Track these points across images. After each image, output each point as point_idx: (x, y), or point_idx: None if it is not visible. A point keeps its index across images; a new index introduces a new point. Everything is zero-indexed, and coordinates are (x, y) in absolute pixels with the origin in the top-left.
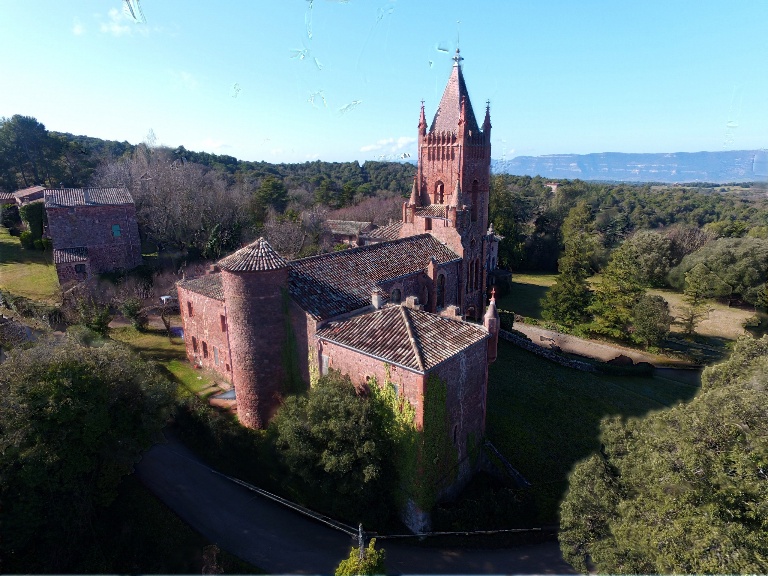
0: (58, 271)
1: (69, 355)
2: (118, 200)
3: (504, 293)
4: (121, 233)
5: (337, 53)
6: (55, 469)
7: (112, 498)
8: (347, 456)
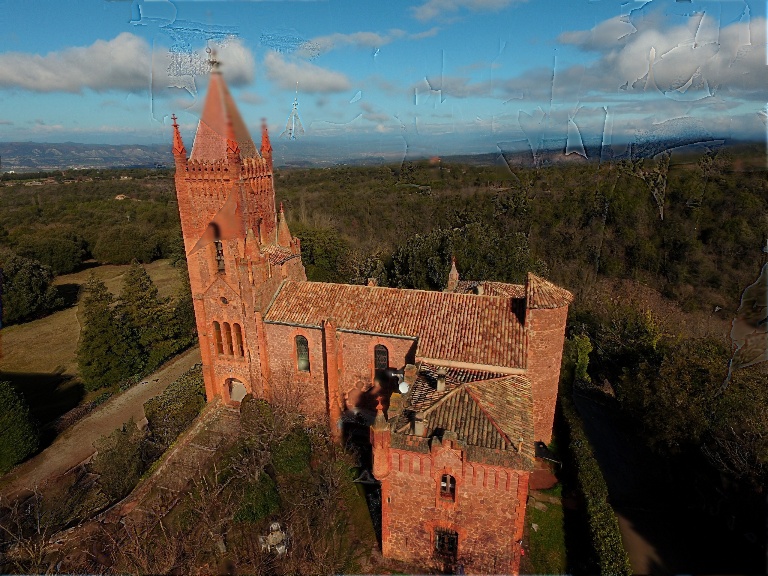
0: None
1: None
2: None
3: None
4: None
5: None
6: None
7: None
8: None
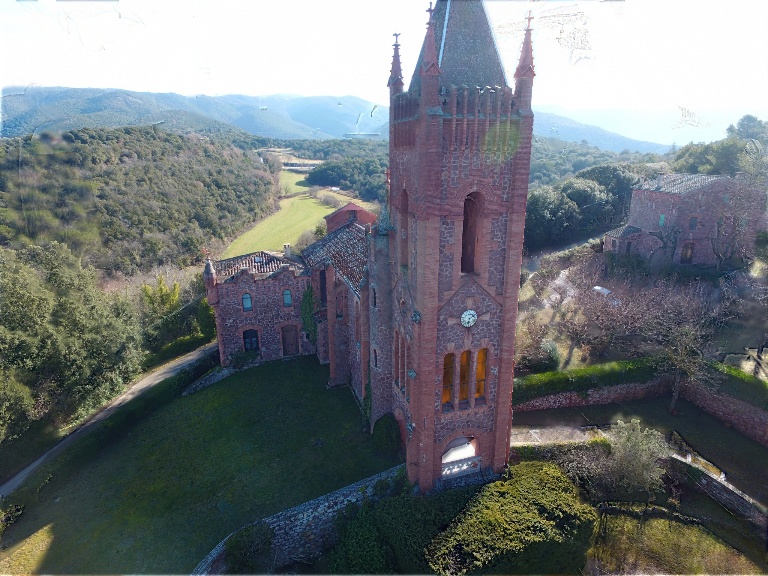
0: None
1: (321, 225)
2: None
3: None
4: (664, 223)
5: None
6: None
7: None
8: None
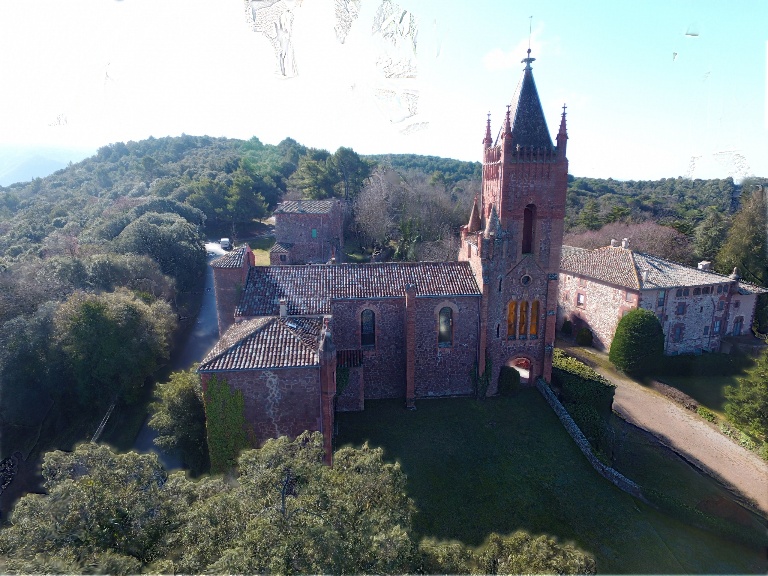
0: (271, 258)
1: (93, 298)
2: (319, 210)
3: (735, 370)
4: (317, 235)
5: (434, 74)
6: (91, 365)
7: (130, 400)
8: None
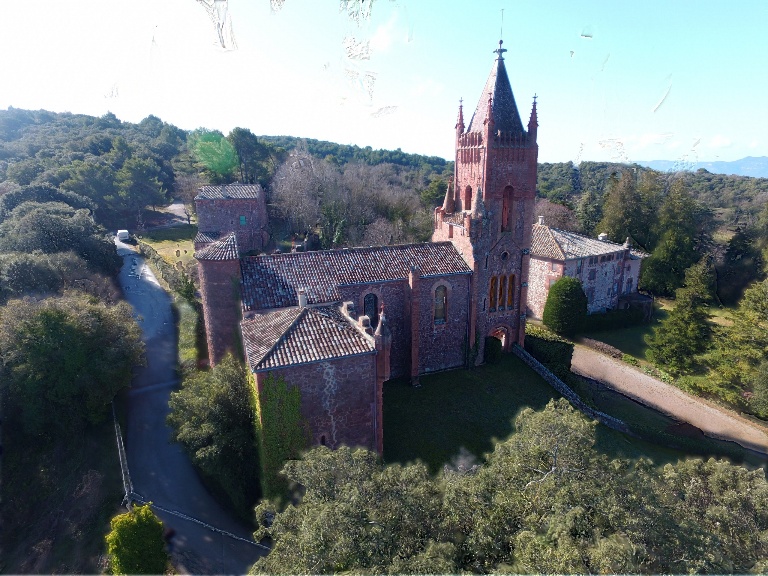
0: (196, 249)
1: (52, 305)
2: (247, 195)
3: (632, 322)
4: (246, 222)
5: (393, 58)
6: (49, 385)
7: (98, 419)
8: (200, 432)
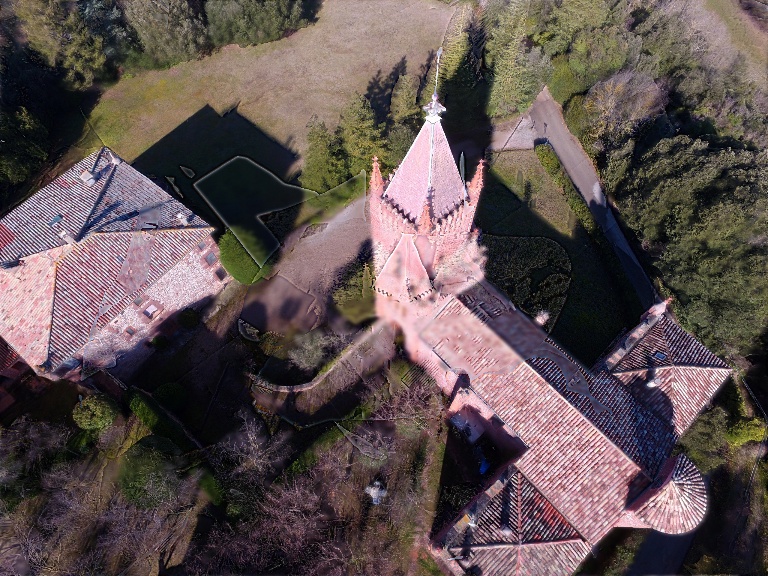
0: None
1: None
2: None
3: None
4: None
5: None
6: None
7: None
8: None
